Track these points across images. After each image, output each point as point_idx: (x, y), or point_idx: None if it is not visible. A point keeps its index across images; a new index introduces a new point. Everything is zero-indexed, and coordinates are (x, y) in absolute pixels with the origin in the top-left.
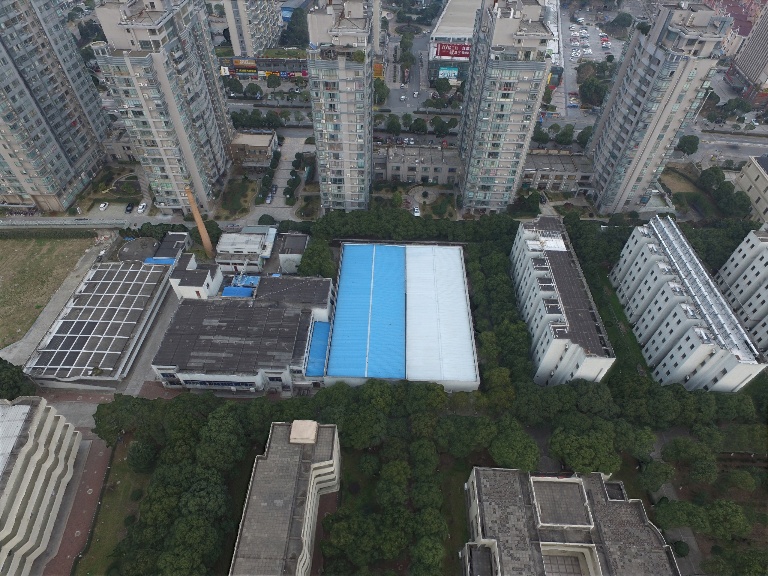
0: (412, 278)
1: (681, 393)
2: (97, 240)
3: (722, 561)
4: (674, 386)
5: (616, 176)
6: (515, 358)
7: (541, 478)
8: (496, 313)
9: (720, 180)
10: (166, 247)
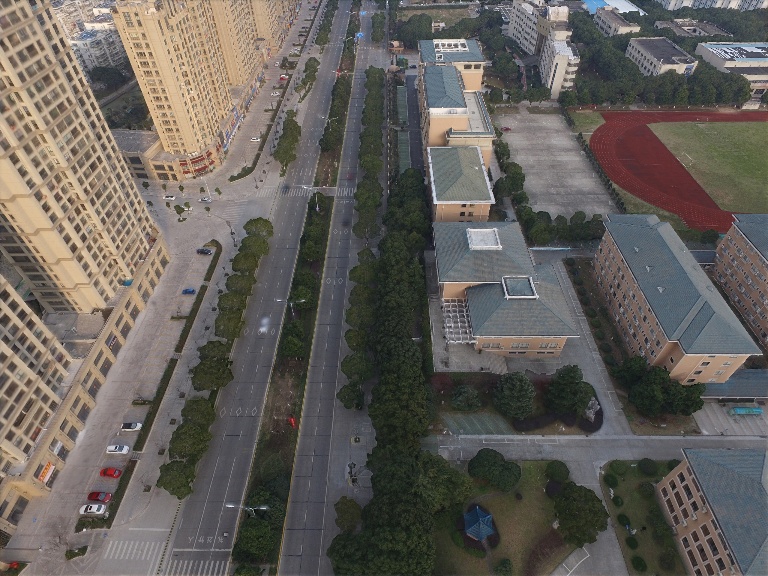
0: (610, 3)
1: (716, 8)
2: (469, 8)
3: None
4: None
5: None
6: (659, 7)
7: (678, 19)
8: (647, 4)
9: None
10: (505, 4)
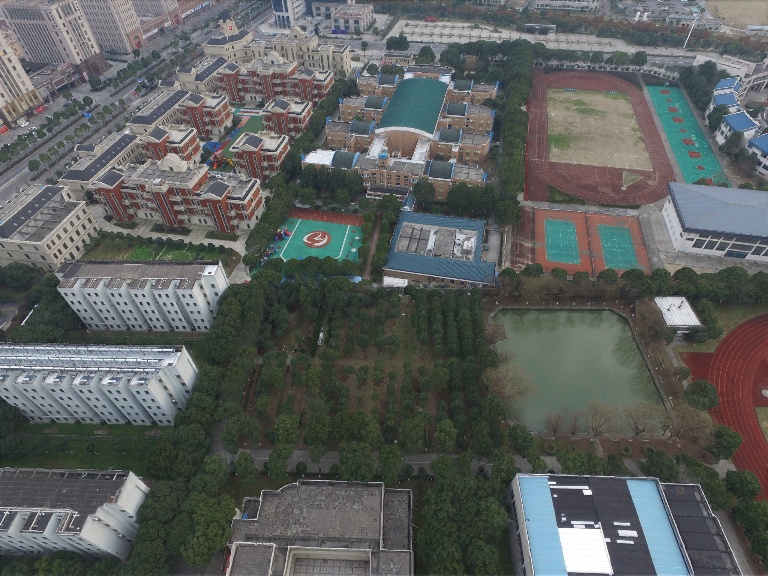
0: None
1: (185, 418)
2: None
3: (313, 447)
4: (177, 420)
5: None
6: None
7: None
8: None
9: None
10: None
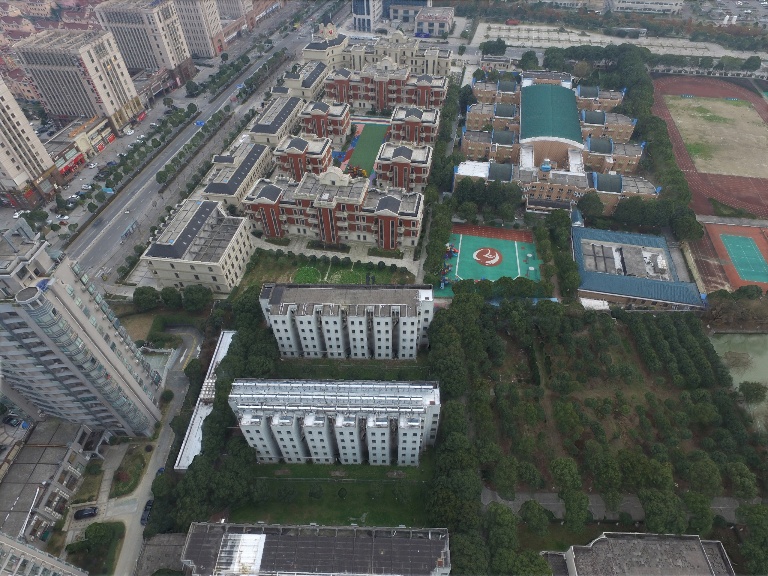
0: None
1: (455, 462)
2: None
3: (611, 496)
4: (446, 464)
5: (124, 409)
6: None
7: None
8: None
9: (156, 294)
10: None
